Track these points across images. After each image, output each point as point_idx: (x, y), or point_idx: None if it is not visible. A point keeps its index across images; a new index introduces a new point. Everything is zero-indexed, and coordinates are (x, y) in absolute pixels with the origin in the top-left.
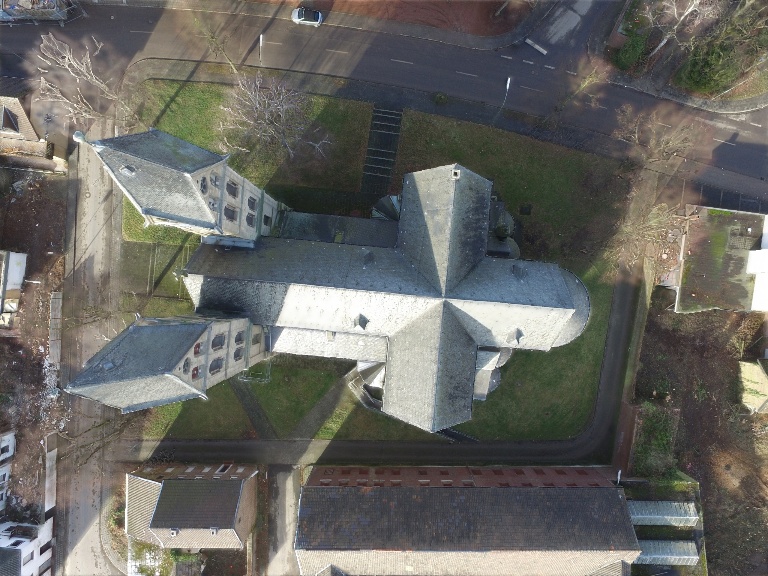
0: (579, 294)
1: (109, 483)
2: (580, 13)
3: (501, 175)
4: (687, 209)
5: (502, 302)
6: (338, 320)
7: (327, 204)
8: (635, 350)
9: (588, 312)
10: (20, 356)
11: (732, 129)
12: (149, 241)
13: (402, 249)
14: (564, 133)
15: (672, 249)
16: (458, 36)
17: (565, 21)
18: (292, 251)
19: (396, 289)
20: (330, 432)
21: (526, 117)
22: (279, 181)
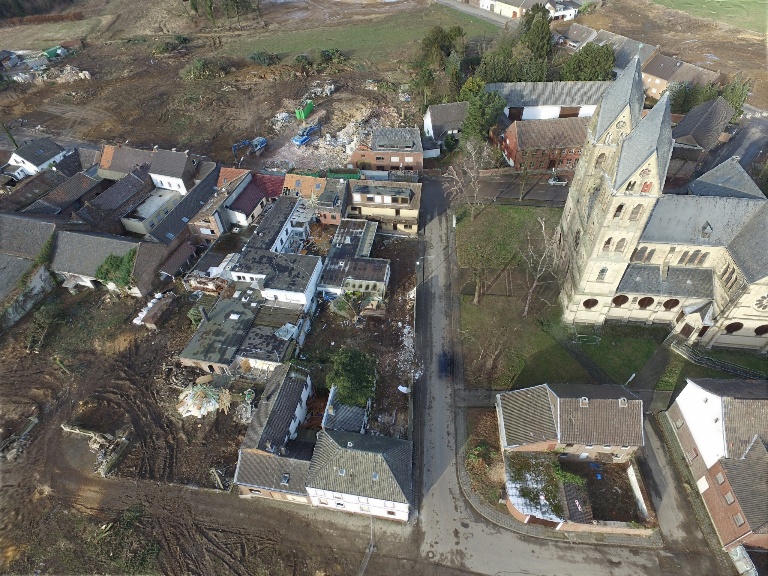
0: None
1: (463, 425)
2: None
3: None
4: None
5: None
6: (689, 231)
7: None
8: None
9: None
10: (381, 329)
11: None
12: (478, 267)
13: None
14: None
15: None
16: None
17: None
18: None
19: None
20: (669, 385)
21: None
22: None
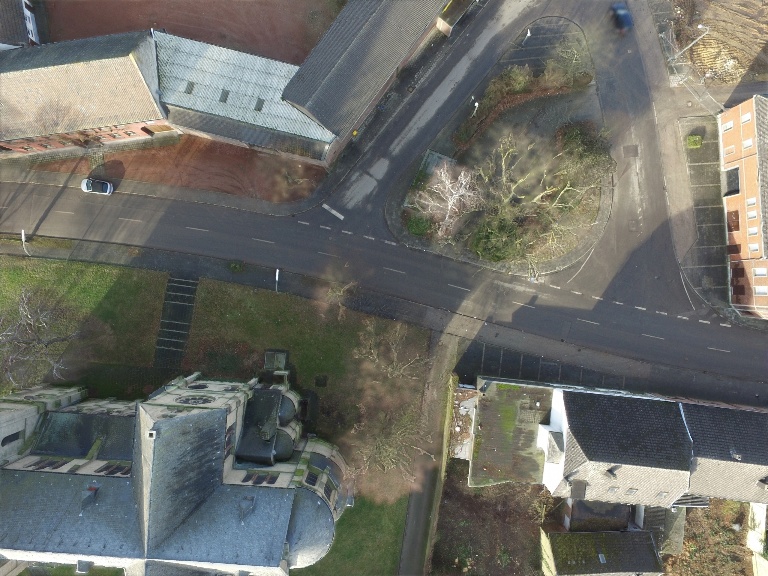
0: (317, 520)
1: None
2: (376, 177)
3: (297, 346)
4: (478, 382)
5: (205, 562)
6: (64, 560)
7: (119, 380)
8: (432, 522)
9: (333, 532)
10: None
11: (531, 292)
12: None
13: (133, 482)
14: (363, 299)
15: (464, 422)
16: (253, 202)
17: (361, 186)
18: (13, 492)
19: (99, 548)
20: None
21: (324, 283)
22: (70, 357)
